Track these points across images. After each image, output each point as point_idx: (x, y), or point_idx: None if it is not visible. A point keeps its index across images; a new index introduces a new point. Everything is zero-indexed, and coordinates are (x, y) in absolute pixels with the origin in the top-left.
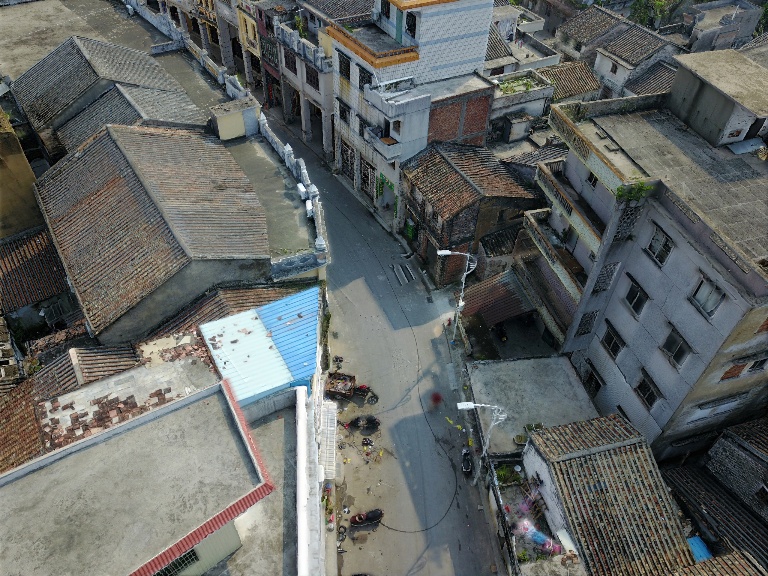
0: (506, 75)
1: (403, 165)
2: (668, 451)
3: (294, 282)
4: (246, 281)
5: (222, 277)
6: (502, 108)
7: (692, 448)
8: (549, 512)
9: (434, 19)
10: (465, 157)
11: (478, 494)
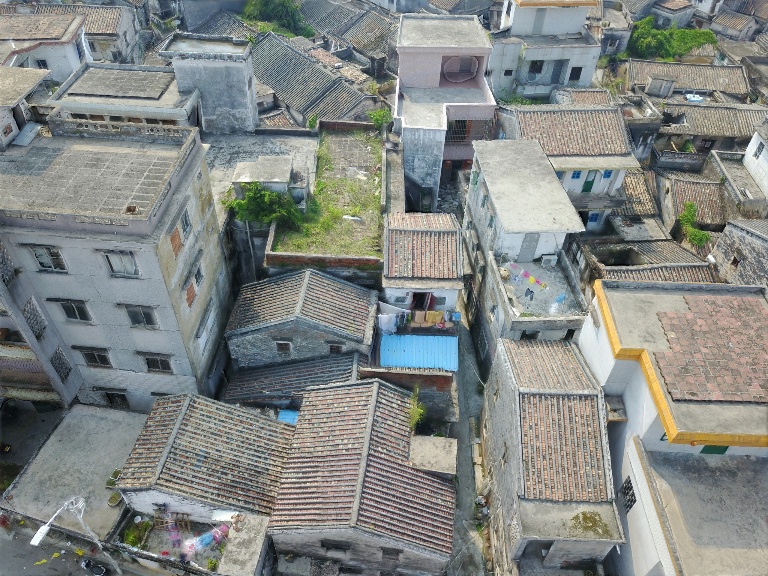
0: None
1: None
2: (212, 384)
3: None
4: None
5: None
6: None
7: (221, 366)
8: (192, 515)
9: None
10: None
11: (132, 575)
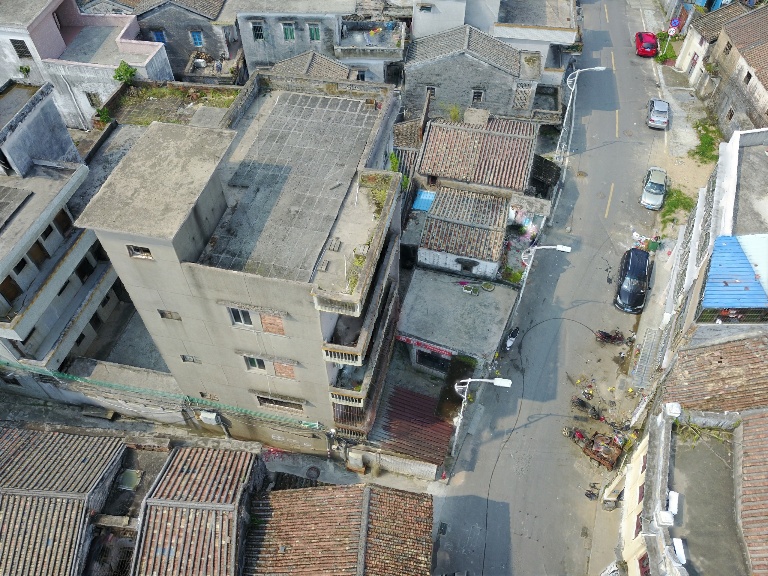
0: None
1: None
2: None
3: None
4: None
5: None
6: None
7: None
8: None
9: None
10: None
11: None
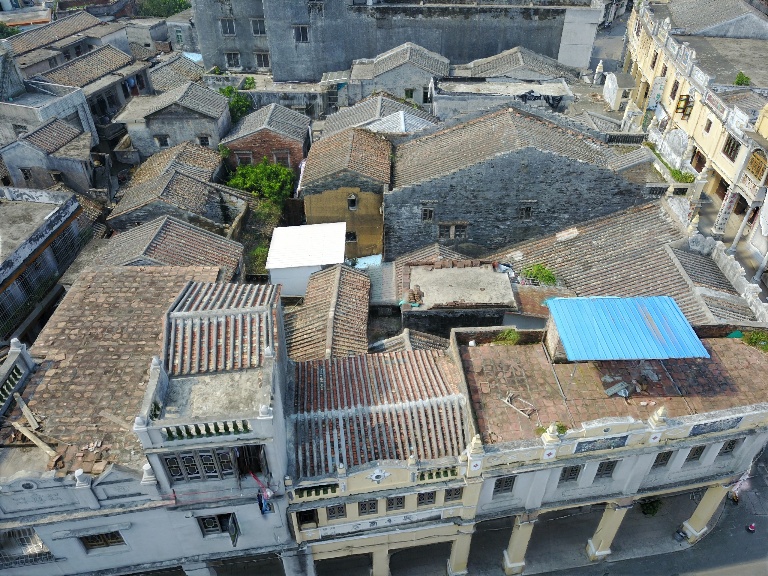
0: None
1: None
2: None
3: None
4: None
5: None
6: None
7: None
8: None
9: None
10: None
11: None
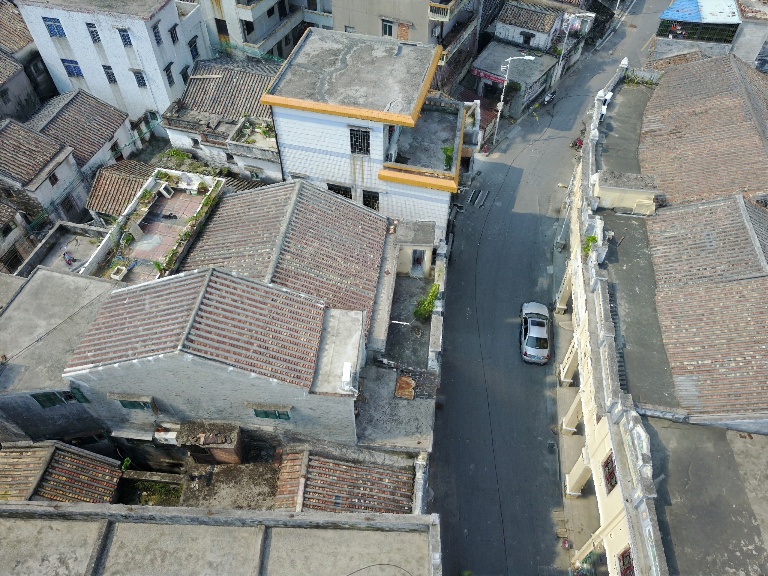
0: None
1: None
2: None
3: None
4: None
5: None
6: None
7: None
8: None
9: None
10: None
11: None
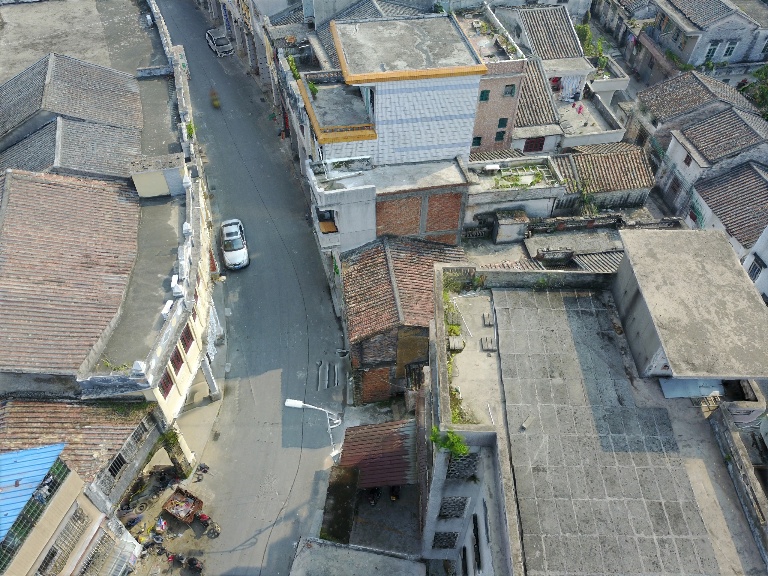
0: (513, 160)
1: (343, 256)
2: None
3: (112, 400)
4: (49, 393)
5: (15, 387)
6: (491, 203)
7: None
8: None
9: (395, 96)
10: (419, 260)
11: None
